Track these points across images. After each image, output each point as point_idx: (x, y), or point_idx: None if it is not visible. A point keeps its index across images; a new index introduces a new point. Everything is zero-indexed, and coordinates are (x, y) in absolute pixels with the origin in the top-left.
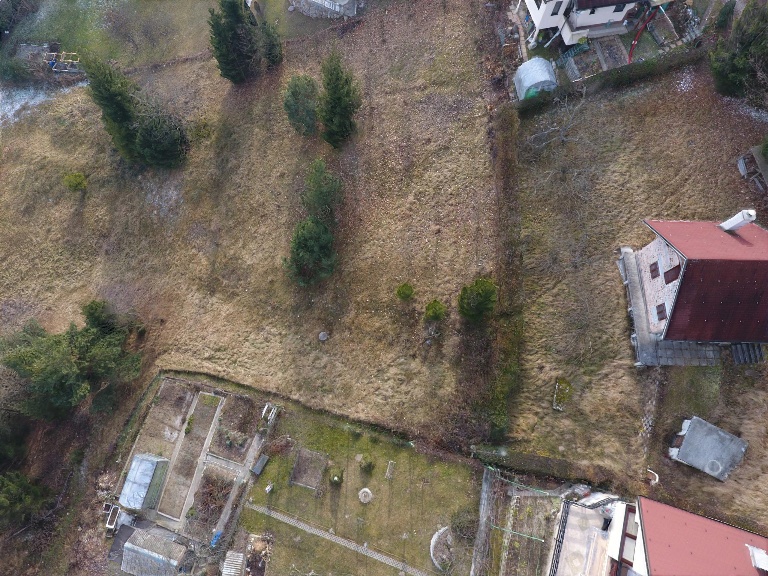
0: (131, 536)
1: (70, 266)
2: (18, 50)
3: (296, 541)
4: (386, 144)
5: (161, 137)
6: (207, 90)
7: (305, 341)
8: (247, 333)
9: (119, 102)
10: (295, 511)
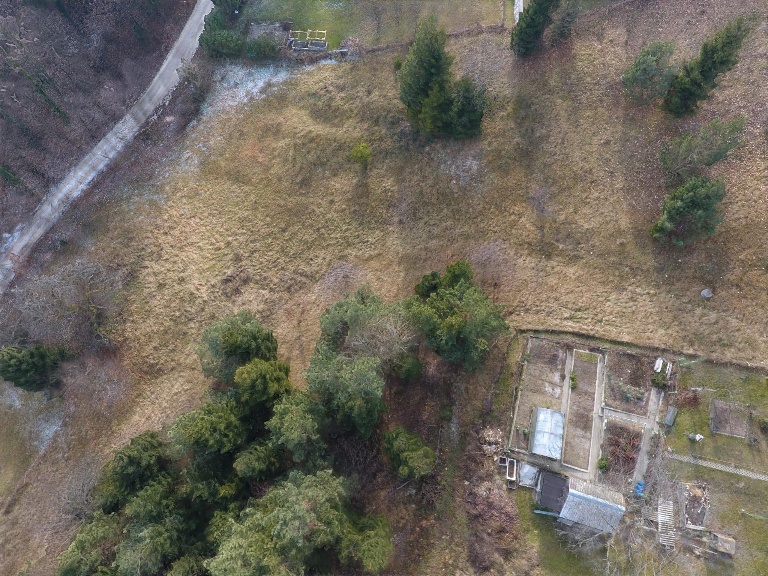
0: (570, 483)
1: (361, 235)
2: (250, 29)
3: (740, 487)
4: (735, 109)
5: (480, 106)
6: (486, 64)
7: (682, 299)
8: (607, 293)
9: (443, 71)
10: (729, 459)
